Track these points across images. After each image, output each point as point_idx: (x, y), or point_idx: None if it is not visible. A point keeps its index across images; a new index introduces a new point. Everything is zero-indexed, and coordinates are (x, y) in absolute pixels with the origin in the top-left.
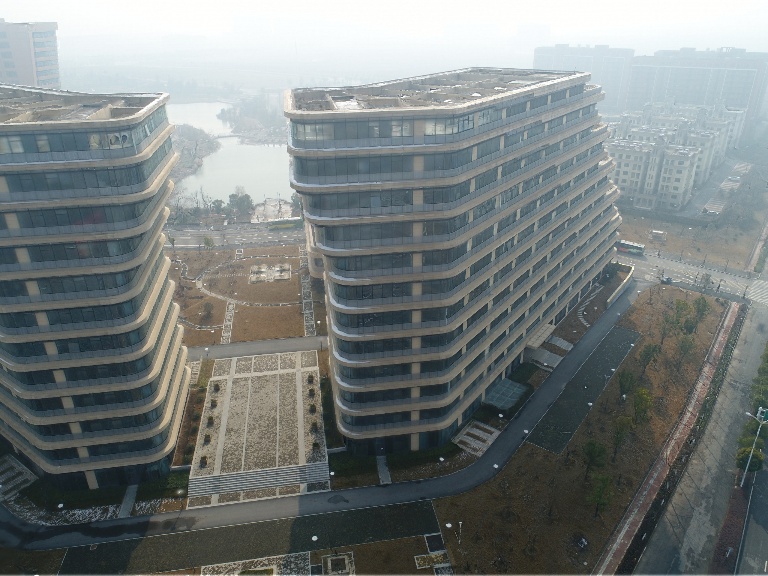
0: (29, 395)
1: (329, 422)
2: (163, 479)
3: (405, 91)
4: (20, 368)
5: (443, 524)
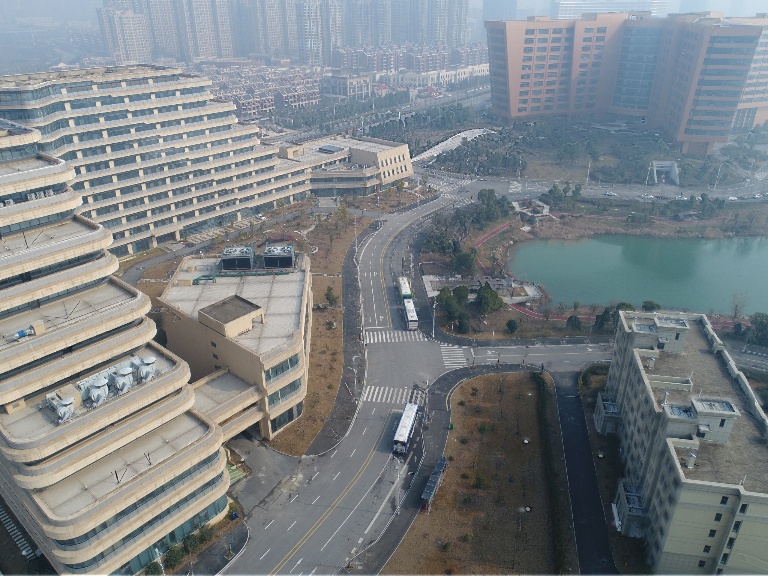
0: None
1: None
2: None
3: None
4: None
5: None
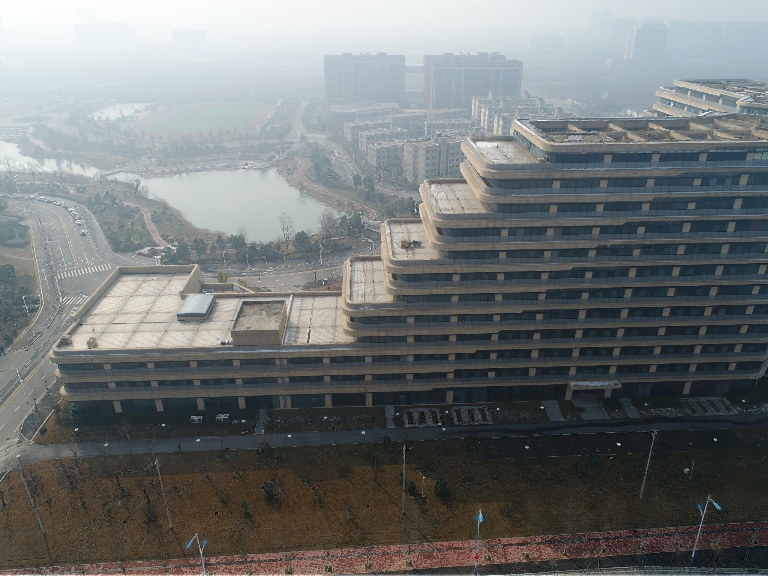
0: None
1: None
2: None
3: (767, 97)
4: None
5: None
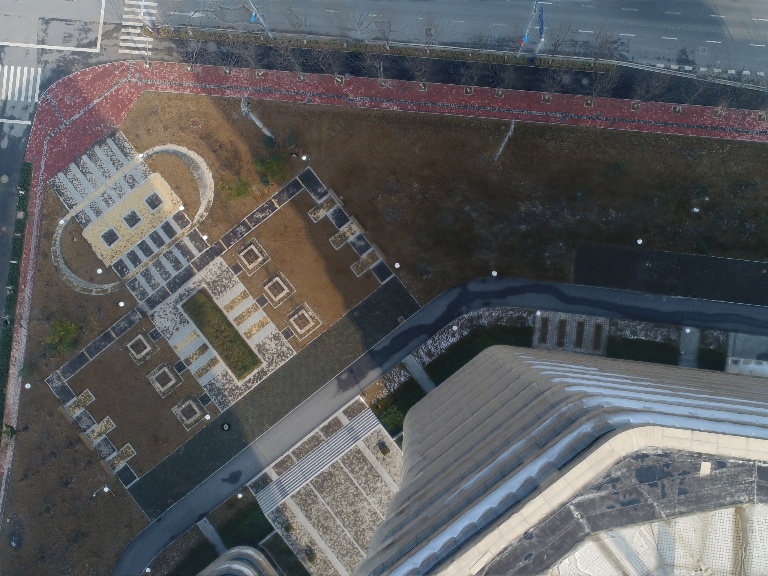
0: (505, 359)
1: (300, 572)
2: None
3: None
4: (511, 363)
5: (128, 499)
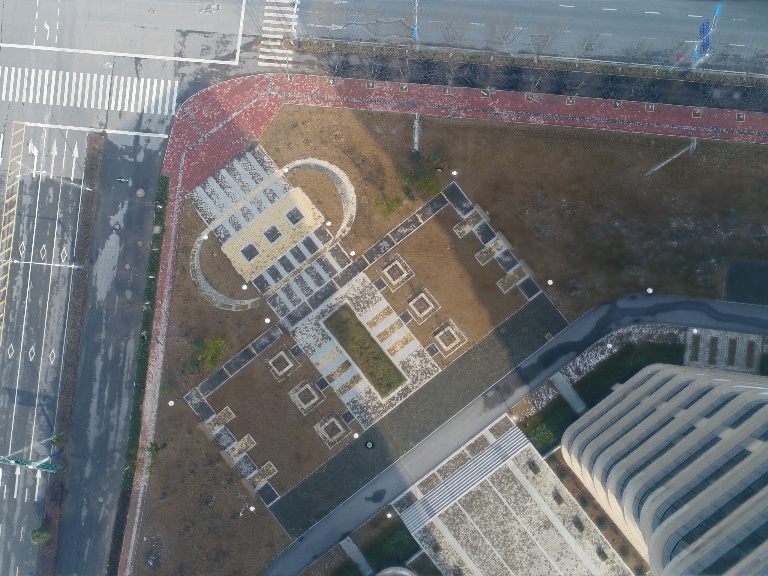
0: (699, 382)
1: None
2: (558, 430)
3: None
4: (720, 388)
5: (269, 517)
